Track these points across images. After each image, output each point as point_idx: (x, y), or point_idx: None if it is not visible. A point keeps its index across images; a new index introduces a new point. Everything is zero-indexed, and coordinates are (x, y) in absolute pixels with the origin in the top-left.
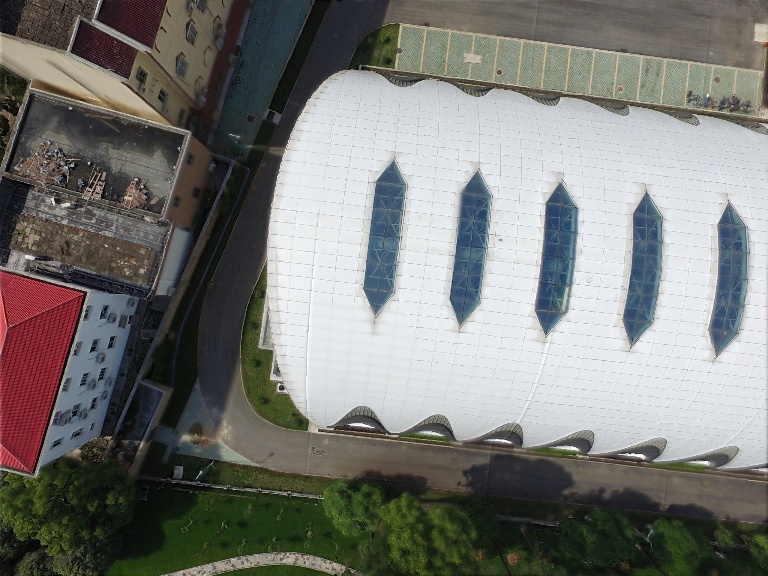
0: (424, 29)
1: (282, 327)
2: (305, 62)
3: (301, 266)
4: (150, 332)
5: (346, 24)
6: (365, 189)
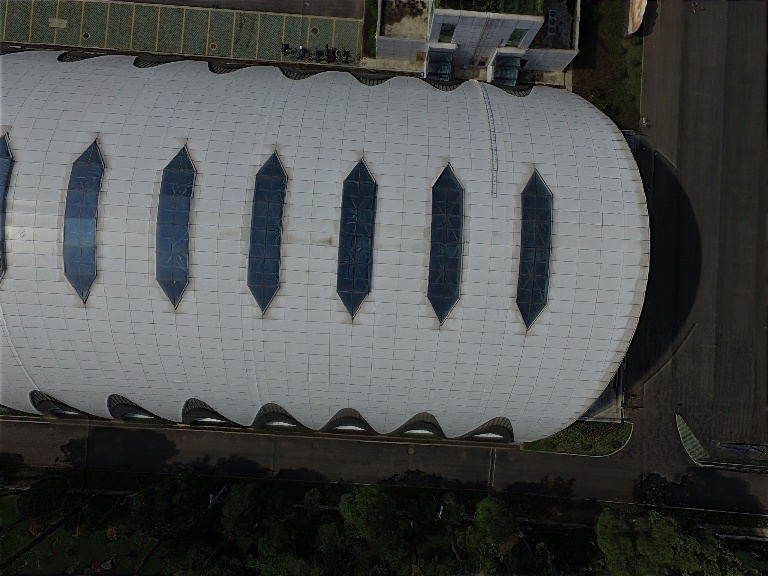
0: None
1: None
2: None
3: None
4: None
5: None
6: None
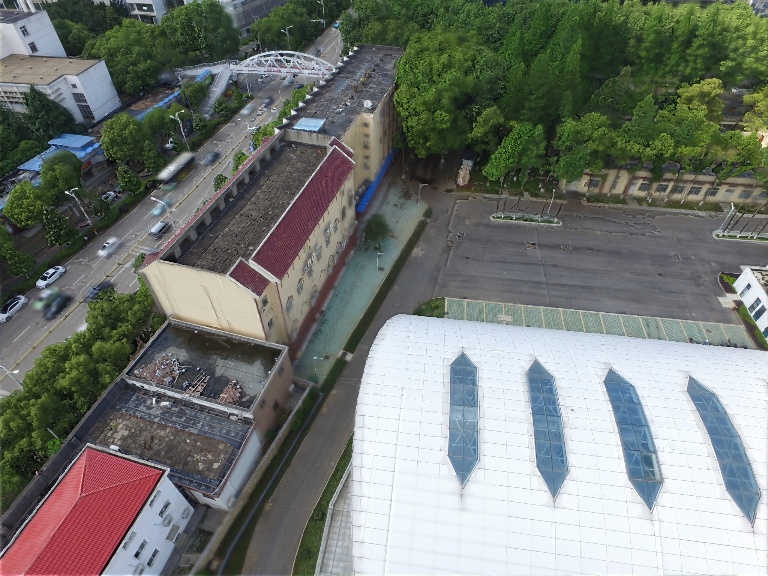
0: (464, 301)
1: (363, 501)
2: (373, 320)
3: (386, 433)
4: (192, 557)
5: (405, 298)
6: (442, 370)
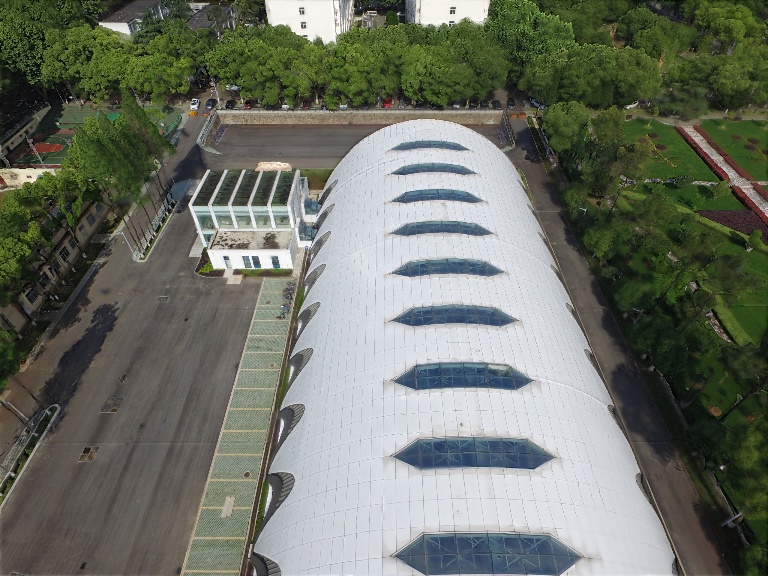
0: (184, 574)
1: None
2: None
3: None
4: None
5: None
6: None
